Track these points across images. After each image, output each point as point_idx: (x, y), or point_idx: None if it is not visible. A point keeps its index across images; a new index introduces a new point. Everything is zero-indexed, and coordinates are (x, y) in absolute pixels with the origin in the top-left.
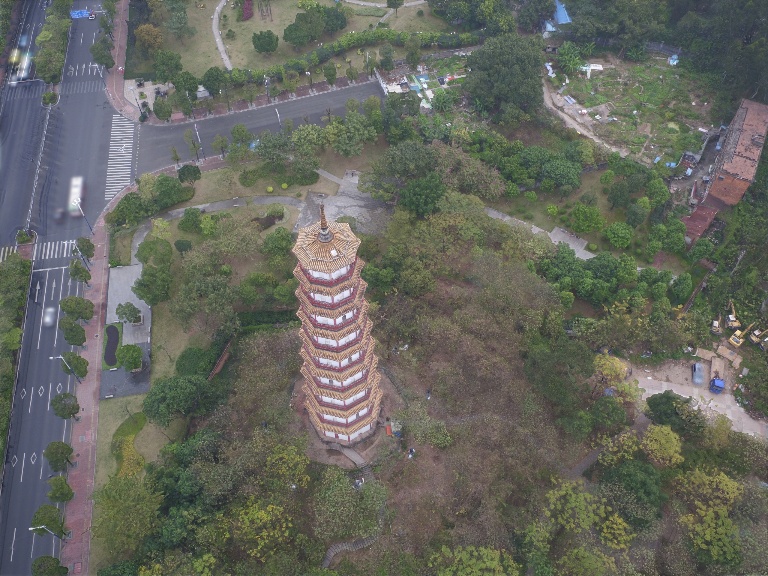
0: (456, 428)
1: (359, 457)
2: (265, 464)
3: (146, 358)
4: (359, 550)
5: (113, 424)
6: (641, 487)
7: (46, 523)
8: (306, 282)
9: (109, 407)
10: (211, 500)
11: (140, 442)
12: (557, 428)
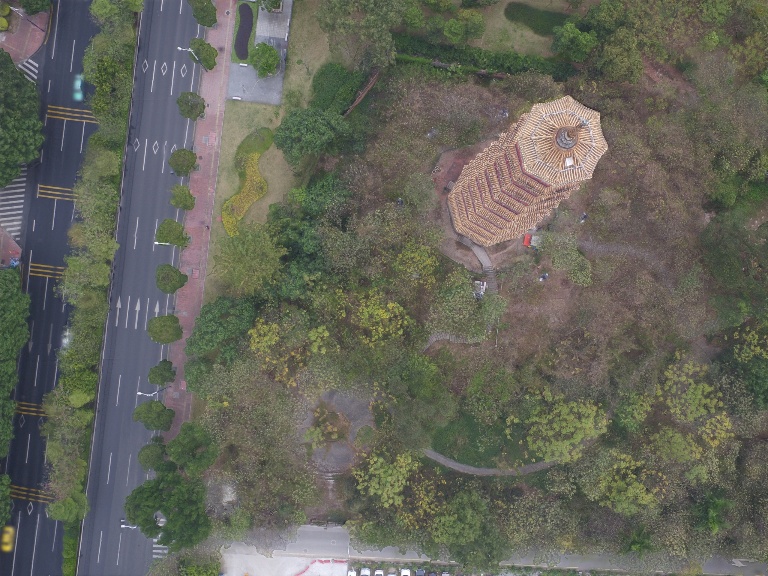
0: (601, 273)
1: (488, 259)
2: (392, 246)
3: (281, 60)
4: (461, 344)
5: (239, 133)
6: (763, 392)
7: (171, 241)
8: (517, 166)
9: (236, 111)
10: (332, 267)
11: (265, 164)
12: (707, 307)
